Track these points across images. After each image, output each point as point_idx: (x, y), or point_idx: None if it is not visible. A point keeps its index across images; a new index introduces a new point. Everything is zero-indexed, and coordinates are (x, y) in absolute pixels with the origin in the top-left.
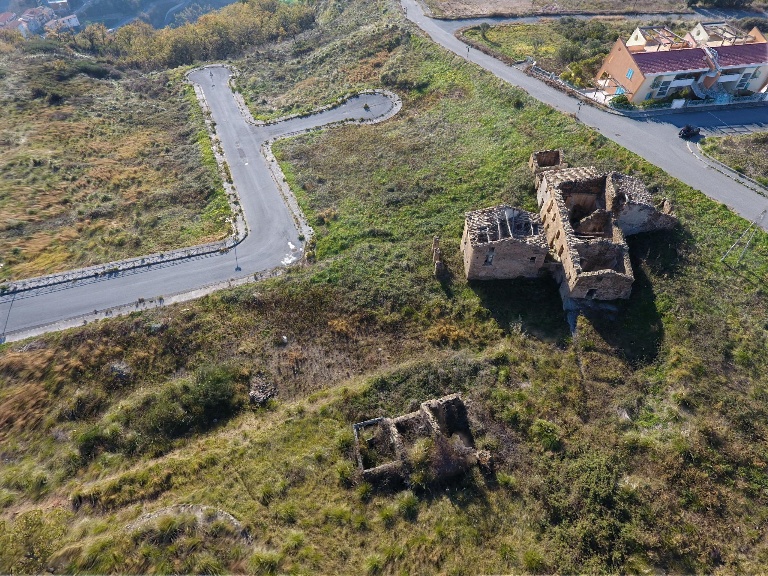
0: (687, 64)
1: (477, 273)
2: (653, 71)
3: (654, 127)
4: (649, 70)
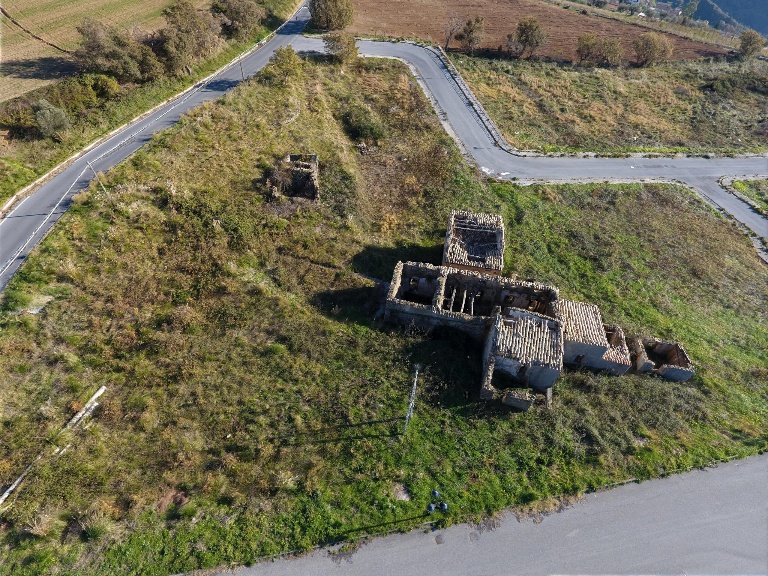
0: None
1: None
2: None
3: None
4: None
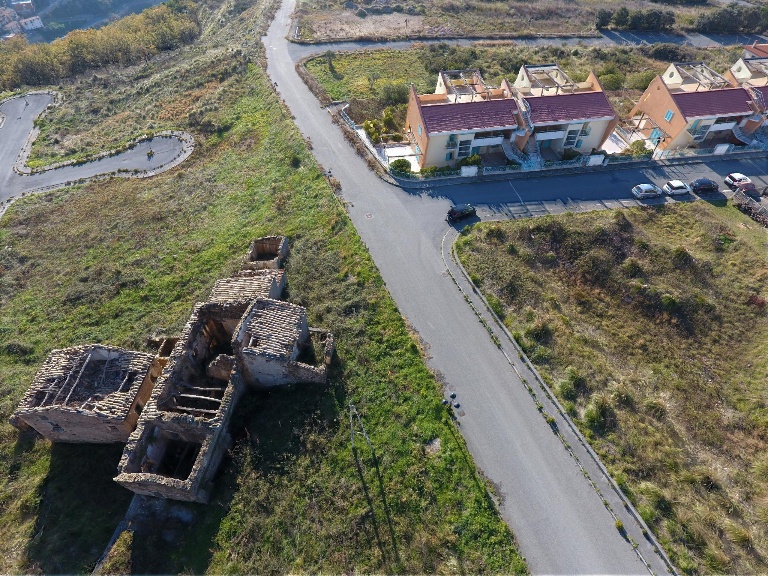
0: (490, 120)
1: (56, 437)
2: (442, 129)
3: (424, 204)
4: (437, 128)
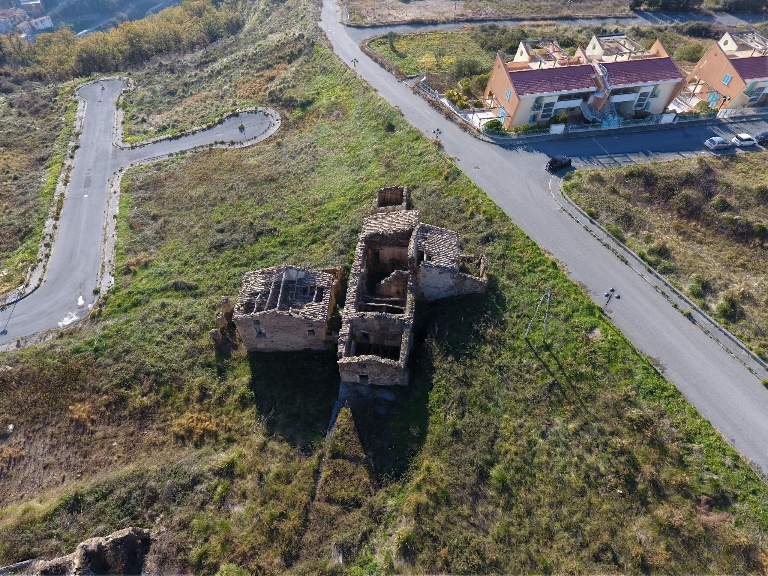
0: (571, 83)
1: (254, 345)
2: (530, 92)
3: (522, 157)
4: (526, 91)
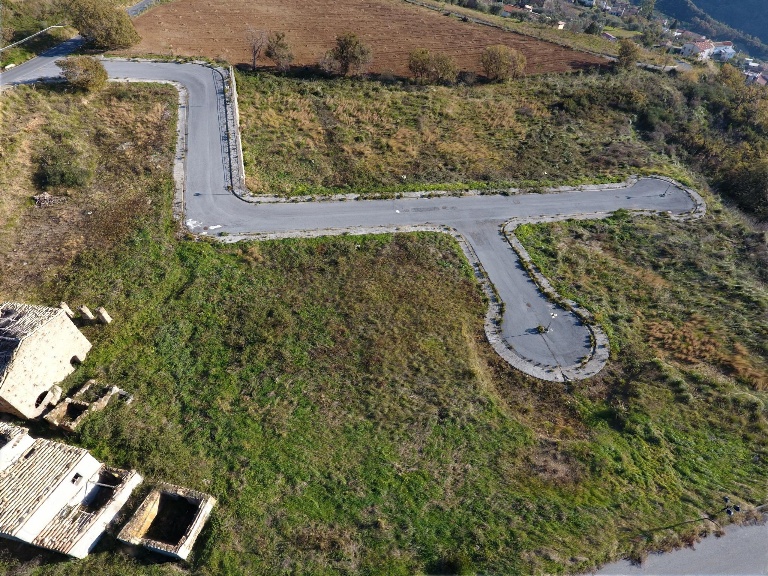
0: None
1: None
2: None
3: None
4: None
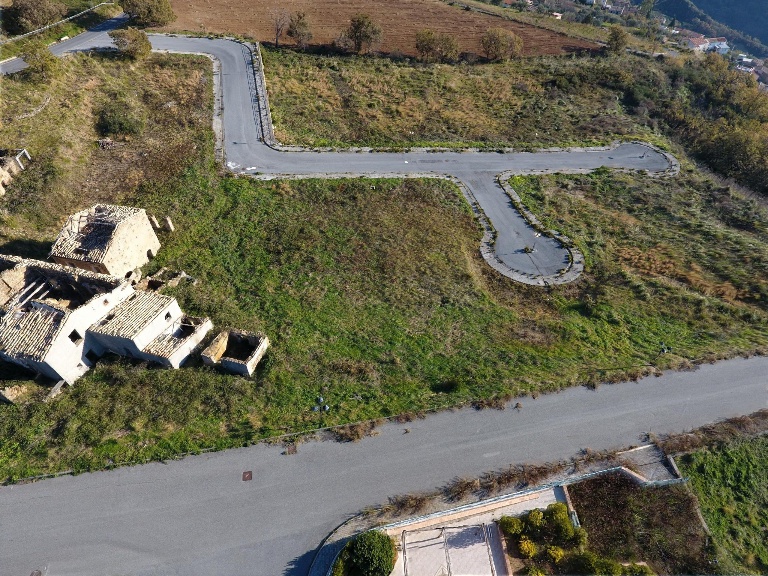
0: None
1: None
2: None
3: None
4: None
